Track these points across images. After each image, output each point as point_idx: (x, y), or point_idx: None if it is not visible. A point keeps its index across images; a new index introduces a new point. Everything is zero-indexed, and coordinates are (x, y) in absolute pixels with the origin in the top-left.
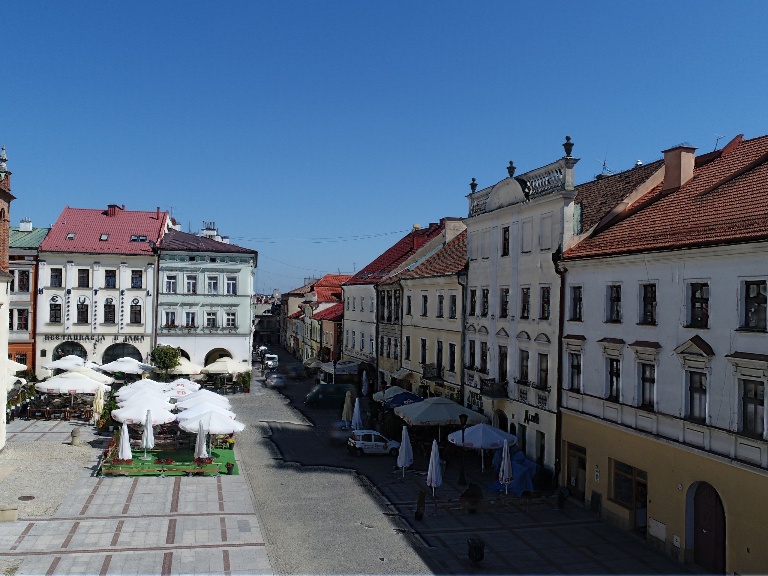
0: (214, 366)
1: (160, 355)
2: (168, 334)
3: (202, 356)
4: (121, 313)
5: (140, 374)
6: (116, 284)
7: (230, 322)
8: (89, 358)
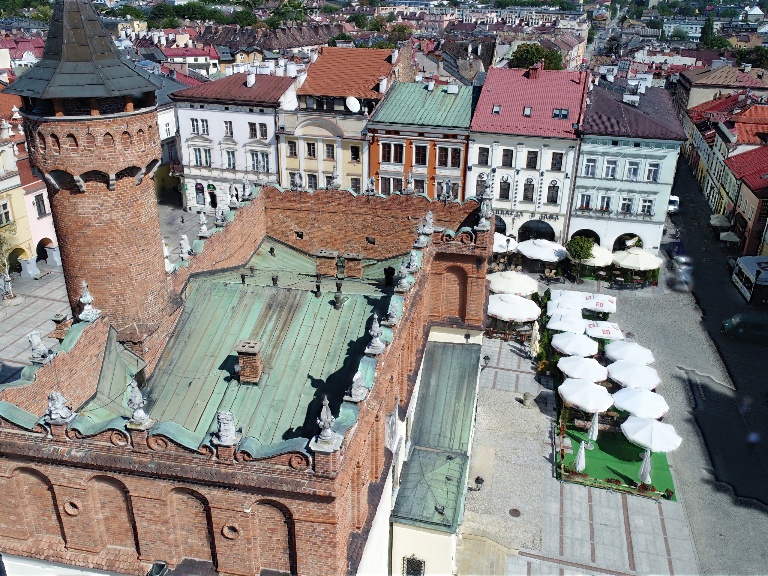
0: (626, 259)
1: (576, 249)
2: (582, 216)
3: (612, 239)
4: (539, 193)
5: (555, 261)
6: (537, 165)
7: (645, 208)
8: (508, 231)
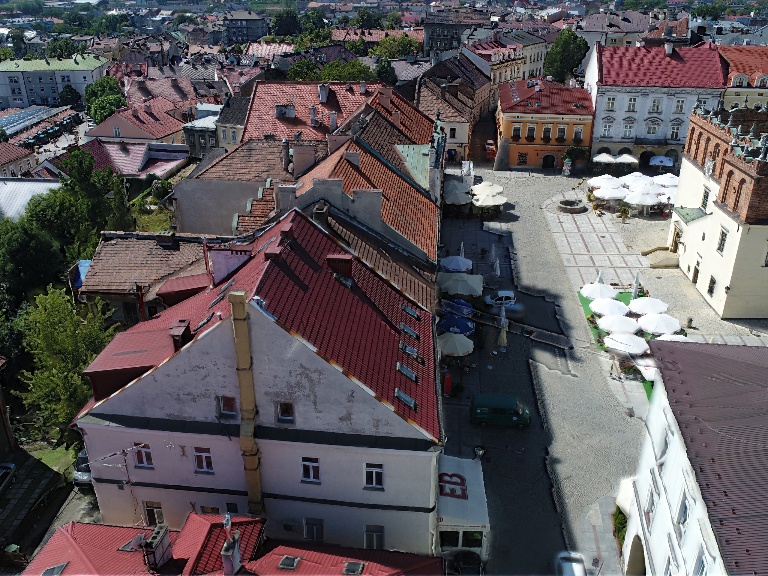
0: None
1: None
2: None
3: None
4: None
5: None
6: None
7: None
8: None
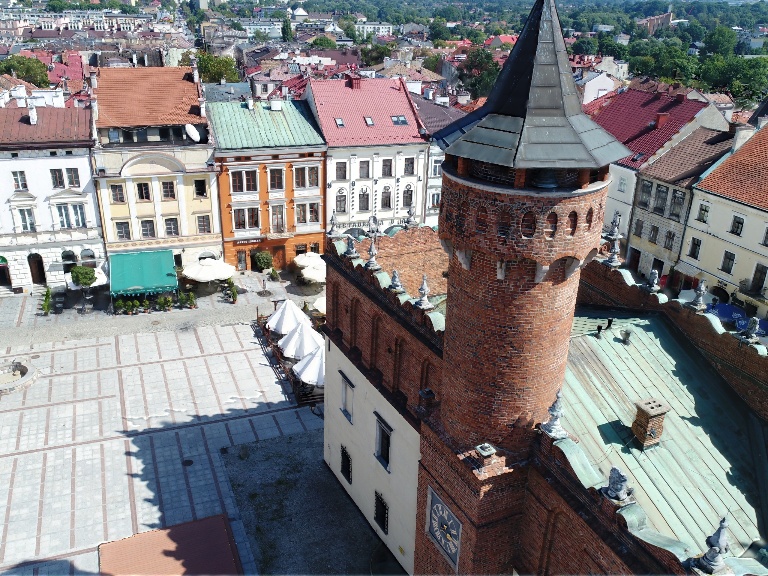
0: None
1: None
2: (434, 214)
3: None
4: (397, 199)
5: None
6: (392, 172)
7: None
8: None
